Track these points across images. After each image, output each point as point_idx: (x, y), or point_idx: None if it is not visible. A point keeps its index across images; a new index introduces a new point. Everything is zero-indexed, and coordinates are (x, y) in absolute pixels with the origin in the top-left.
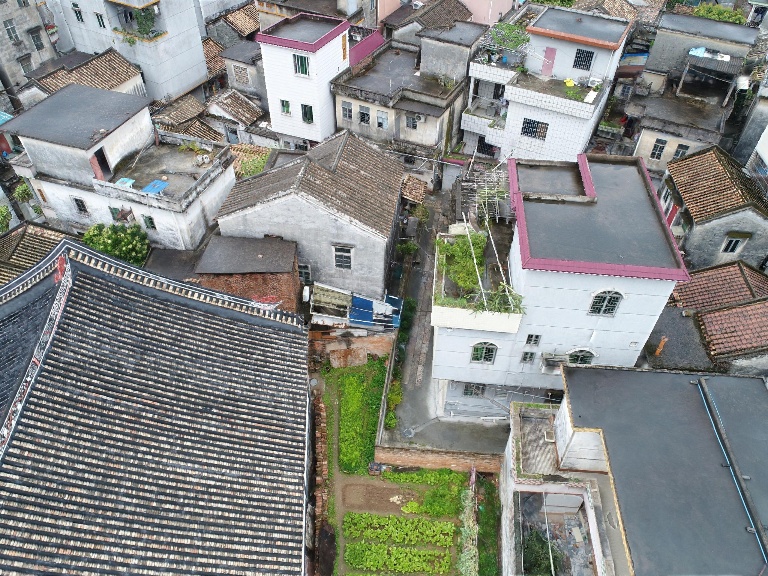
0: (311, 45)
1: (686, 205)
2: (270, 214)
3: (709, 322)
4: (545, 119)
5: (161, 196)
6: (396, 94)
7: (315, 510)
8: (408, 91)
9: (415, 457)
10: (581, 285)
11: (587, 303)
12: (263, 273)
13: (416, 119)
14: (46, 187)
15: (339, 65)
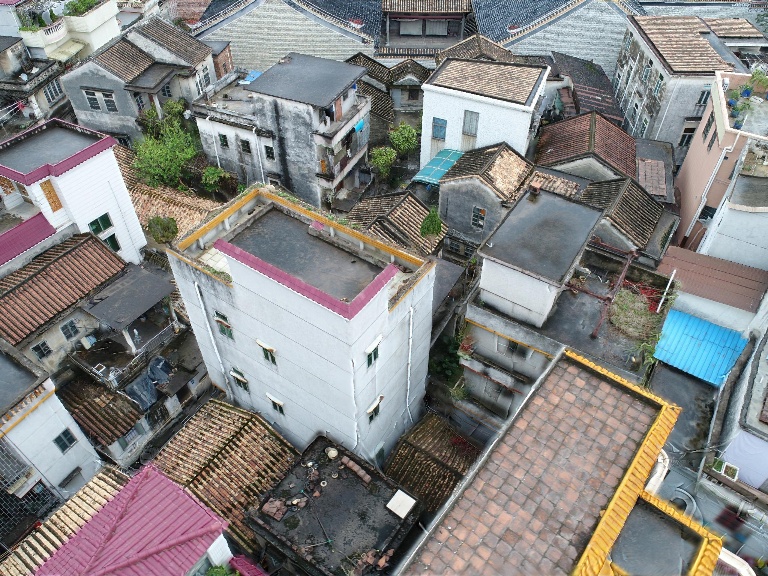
0: None
1: None
2: None
3: None
4: None
5: None
6: None
7: None
8: None
9: None
10: None
11: None
12: None
13: None
14: None
15: None
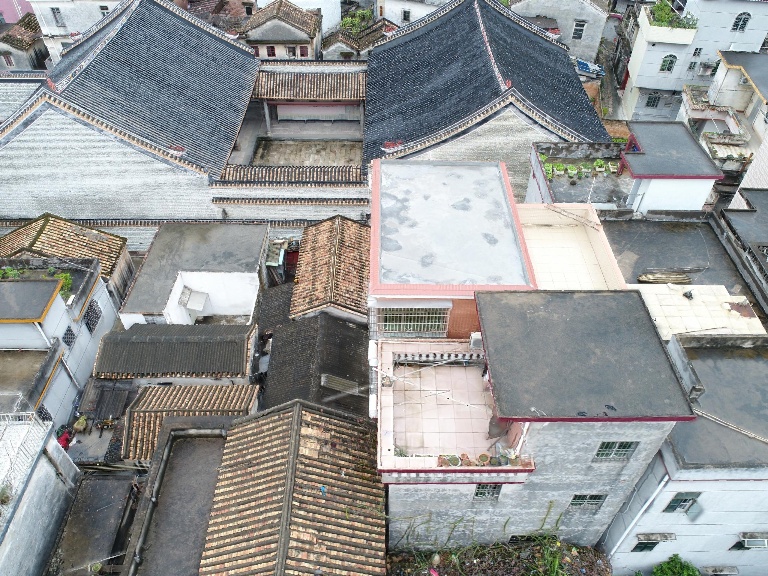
0: None
1: None
2: (544, 0)
3: None
4: None
5: None
6: None
7: None
8: None
9: (623, 128)
10: (730, 10)
11: (731, 23)
12: None
13: None
14: (387, 4)
15: None
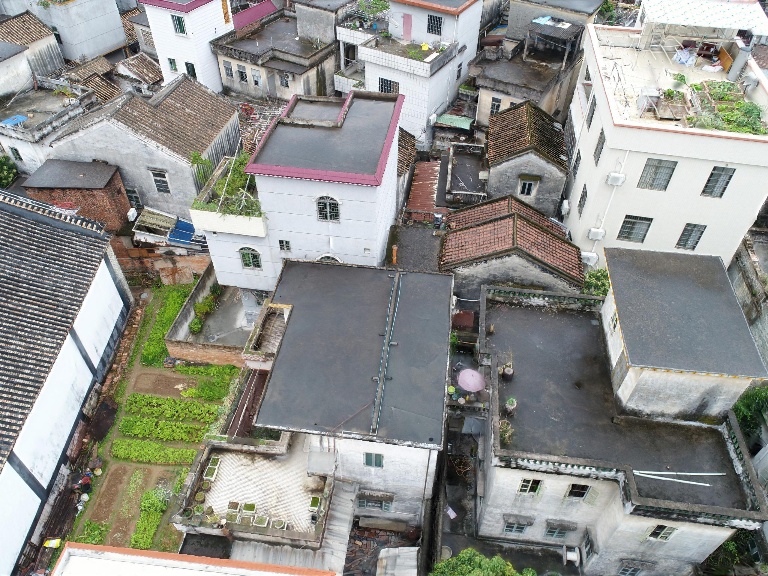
0: (183, 6)
1: None
2: (92, 140)
3: (450, 239)
4: (395, 78)
5: (16, 127)
6: (265, 53)
7: (102, 388)
8: (277, 51)
9: (201, 352)
10: (302, 191)
11: (313, 209)
12: (80, 189)
13: (285, 77)
14: None
15: (221, 27)
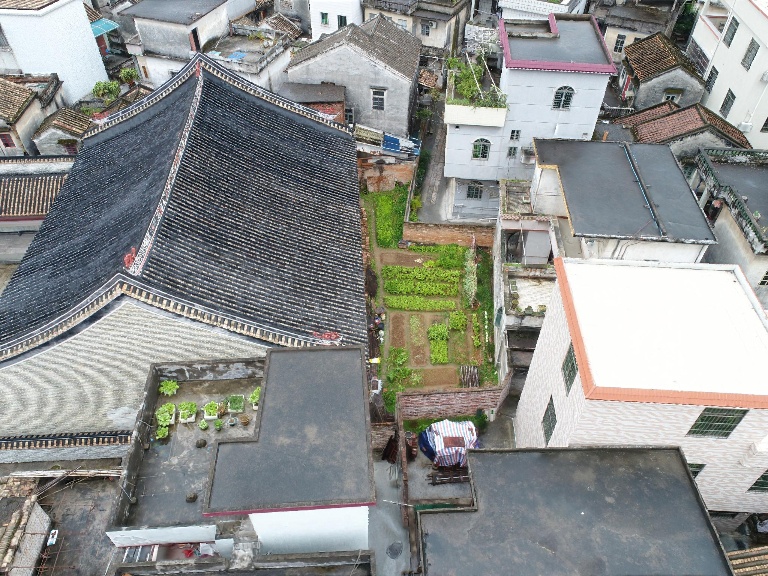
0: None
1: (635, 72)
2: (327, 63)
3: (640, 129)
4: None
5: (242, 60)
6: (413, 4)
7: None
8: (423, 3)
9: (432, 233)
10: (546, 83)
11: (551, 99)
12: (323, 103)
13: (429, 25)
14: (150, 64)
15: None
